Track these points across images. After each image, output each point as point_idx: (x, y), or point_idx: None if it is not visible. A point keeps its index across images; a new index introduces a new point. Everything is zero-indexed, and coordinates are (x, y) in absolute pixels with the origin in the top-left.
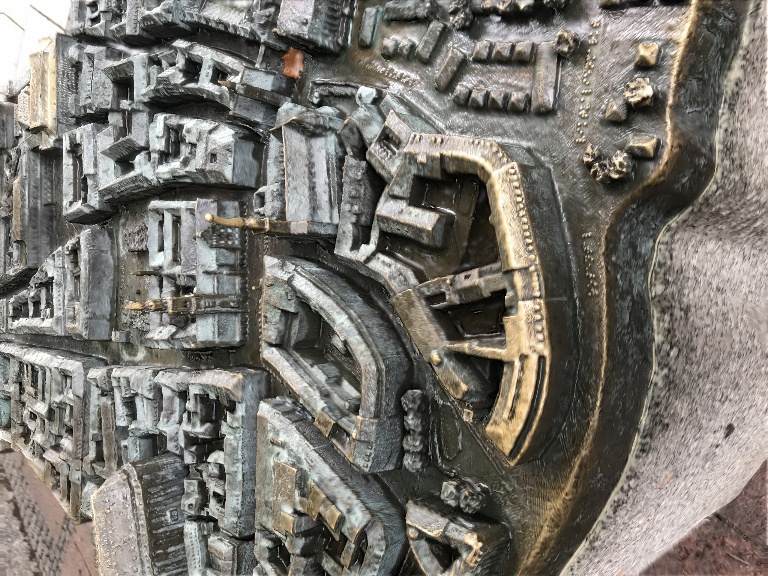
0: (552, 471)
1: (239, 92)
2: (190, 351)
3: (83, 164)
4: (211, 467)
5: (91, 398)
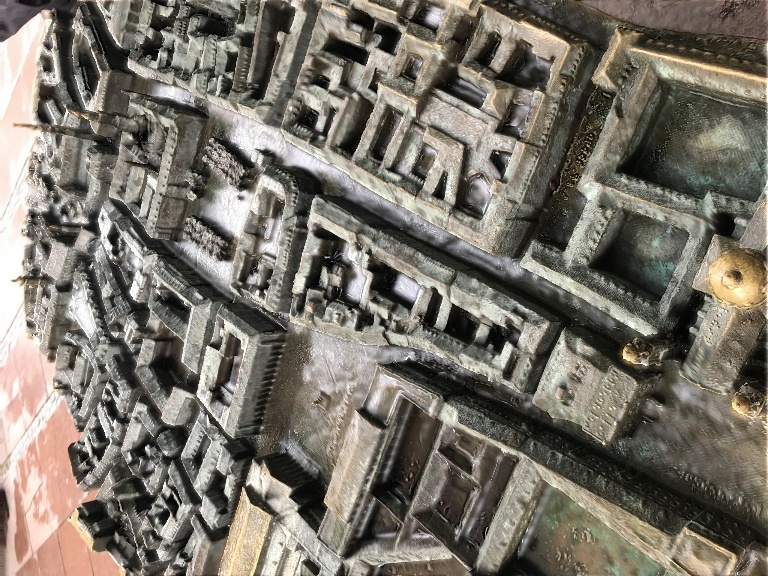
0: (75, 7)
1: (63, 223)
2: (199, 110)
3: (207, 359)
4: (172, 3)
5: (268, 86)
